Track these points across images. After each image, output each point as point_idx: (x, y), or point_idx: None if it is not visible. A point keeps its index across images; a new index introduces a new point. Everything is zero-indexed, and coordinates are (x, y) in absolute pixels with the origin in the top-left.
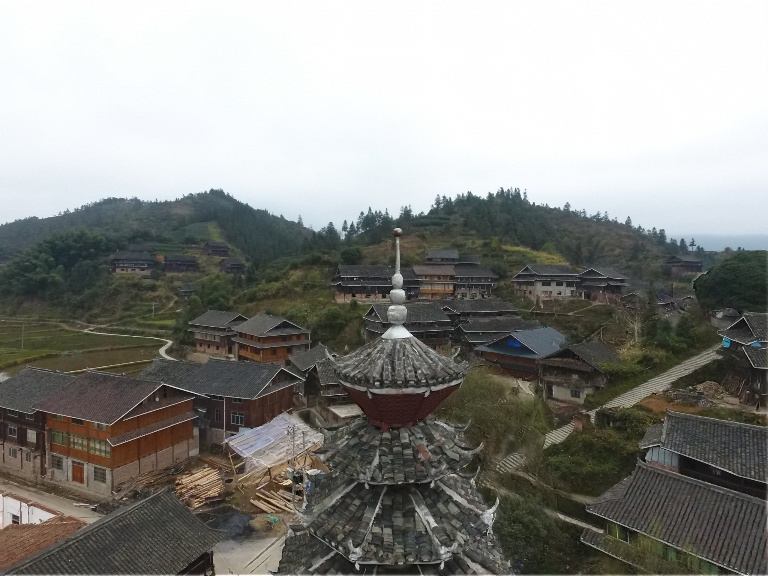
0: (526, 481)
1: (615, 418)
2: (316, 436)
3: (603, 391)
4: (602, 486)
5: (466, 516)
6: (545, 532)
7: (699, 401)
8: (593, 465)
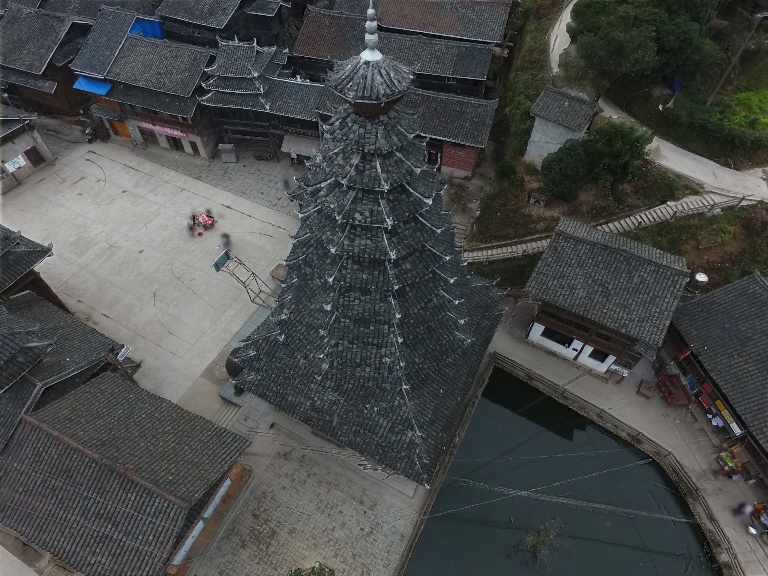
0: None
1: None
2: None
3: None
4: None
5: None
6: None
7: None
8: None
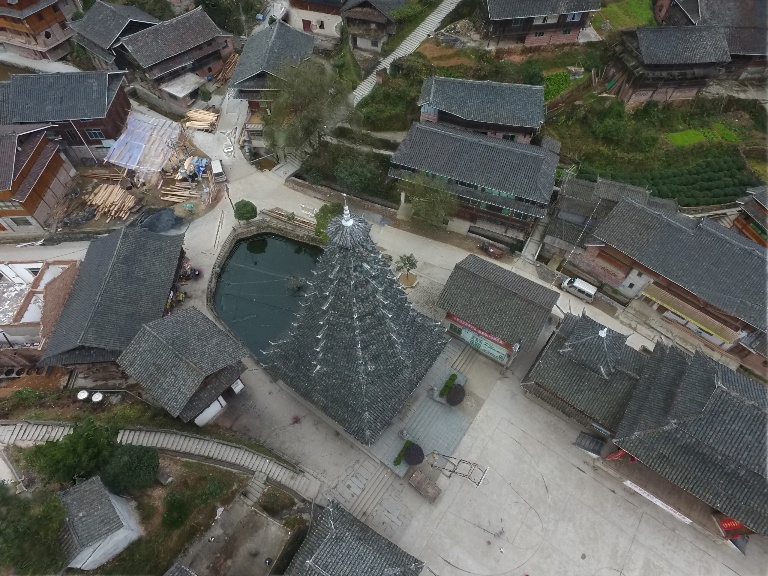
0: (350, 130)
1: (403, 68)
2: (174, 127)
3: (394, 37)
4: (396, 123)
5: (374, 259)
6: (370, 175)
7: (456, 43)
8: (390, 110)
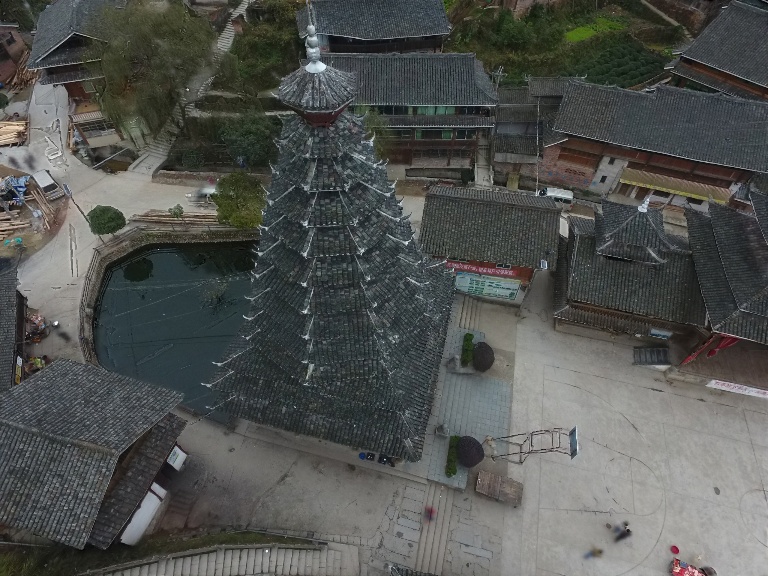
0: (219, 97)
1: (263, 11)
2: None
3: None
4: (275, 78)
5: (364, 147)
6: (268, 131)
7: None
8: (263, 63)
